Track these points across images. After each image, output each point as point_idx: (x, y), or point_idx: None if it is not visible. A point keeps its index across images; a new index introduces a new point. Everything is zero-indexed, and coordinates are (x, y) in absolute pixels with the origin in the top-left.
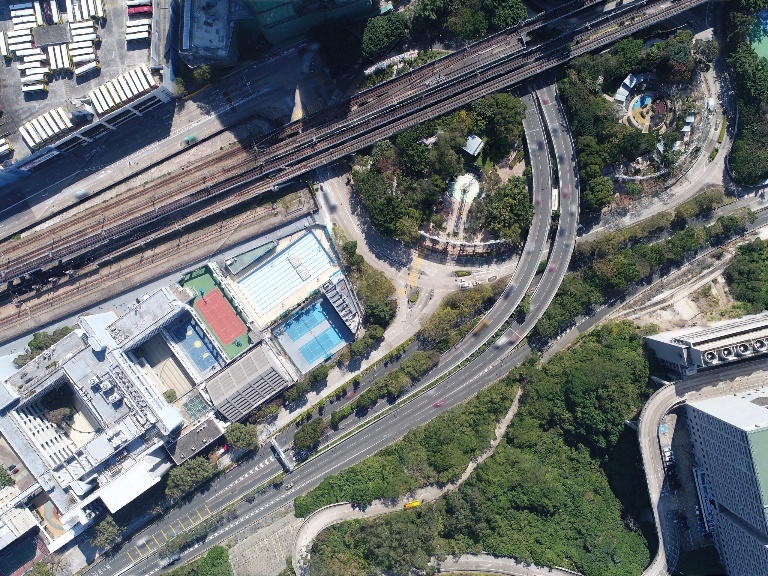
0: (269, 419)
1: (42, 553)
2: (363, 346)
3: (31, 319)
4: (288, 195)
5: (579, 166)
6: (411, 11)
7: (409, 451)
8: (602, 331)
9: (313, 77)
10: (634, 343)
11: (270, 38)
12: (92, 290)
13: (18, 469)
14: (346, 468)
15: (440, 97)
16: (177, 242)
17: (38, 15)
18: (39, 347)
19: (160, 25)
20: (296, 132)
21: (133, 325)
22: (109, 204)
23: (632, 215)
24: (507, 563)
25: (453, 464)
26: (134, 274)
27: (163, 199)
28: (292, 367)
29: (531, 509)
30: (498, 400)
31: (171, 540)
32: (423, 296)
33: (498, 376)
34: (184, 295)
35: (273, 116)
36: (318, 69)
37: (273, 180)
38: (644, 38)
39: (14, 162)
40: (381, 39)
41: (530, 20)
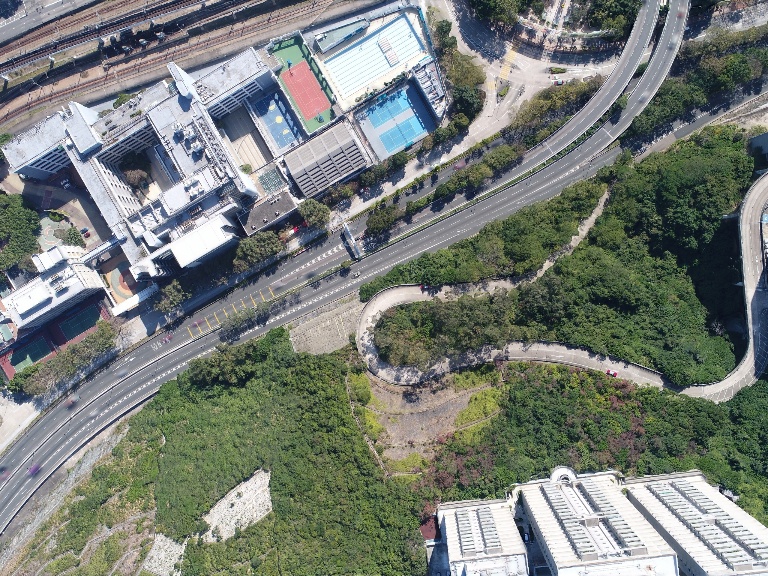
0: (342, 206)
1: None
2: (447, 132)
3: (117, 84)
4: None
5: None
6: None
7: (485, 241)
8: (703, 133)
9: None
10: (738, 143)
11: None
12: (179, 59)
13: (90, 233)
14: None
15: None
16: (268, 16)
17: None
18: None
19: None
20: None
21: (219, 83)
22: None
23: (745, 22)
24: (580, 355)
25: (531, 254)
26: (222, 46)
27: None
28: (371, 154)
29: (610, 305)
30: (584, 196)
31: None
32: (513, 91)
33: (585, 178)
34: (272, 62)
35: None
36: None
37: None
38: None
39: None
40: None
41: None
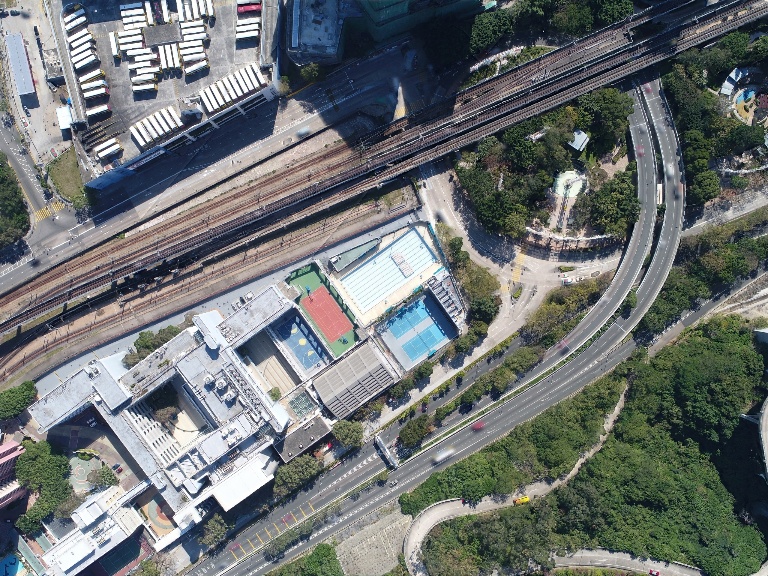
0: (372, 416)
1: (146, 552)
2: (469, 342)
3: (135, 318)
4: (391, 192)
5: (685, 160)
6: (519, 7)
7: (517, 447)
8: (710, 325)
9: (416, 74)
10: (745, 337)
11: (377, 35)
12: (195, 289)
13: (122, 468)
14: (451, 465)
15: (546, 93)
16: (280, 240)
17: (149, 15)
18: (146, 346)
19: (267, 24)
20: (400, 129)
21: (243, 323)
22: (214, 203)
23: (735, 209)
24: (623, 558)
25: (564, 459)
26: (237, 272)
27: (268, 197)
28: (395, 364)
29: (644, 504)
30: (606, 395)
31: (275, 538)
32: (526, 292)
33: (603, 371)
34: (292, 293)
35: (376, 113)
36: (421, 66)
37: (378, 177)
38: (748, 32)
39: (123, 162)
40: (489, 35)
41: (638, 15)
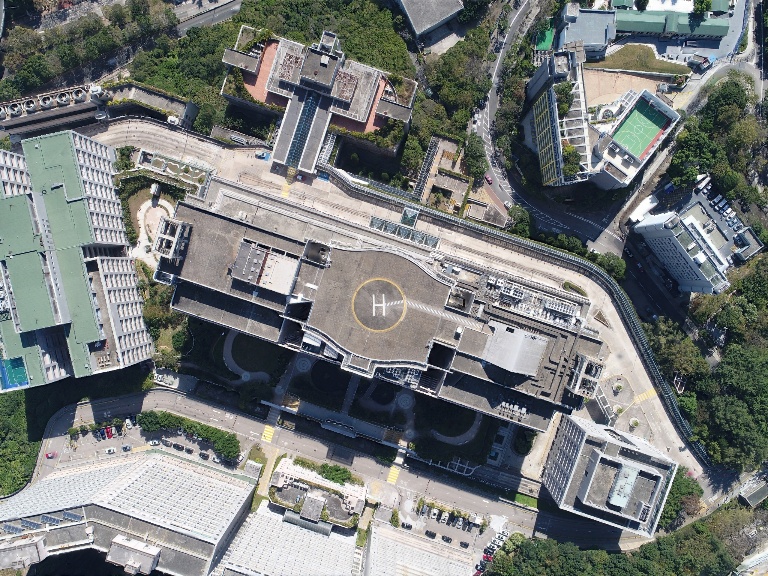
0: None
1: None
2: None
3: None
4: None
5: None
6: None
7: None
8: None
9: None
10: None
11: None
12: None
13: None
14: None
15: None
16: None
17: None
18: None
19: None
20: None
21: None
22: None
23: (72, 19)
24: None
25: None
26: None
27: None
28: None
29: None
30: None
31: None
32: None
33: None
34: None
35: None
36: None
37: None
38: None
39: None
40: None
41: None
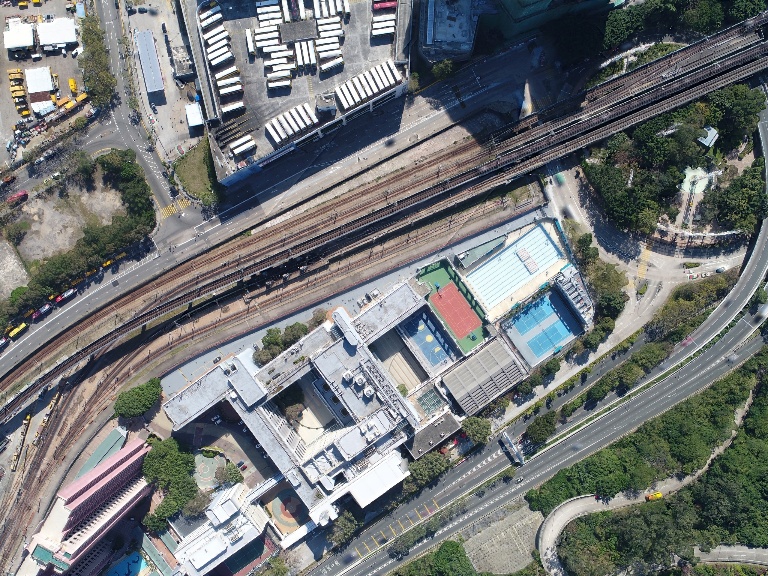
0: None
1: (270, 550)
2: None
3: (260, 315)
4: (517, 189)
5: None
6: (653, 4)
7: (648, 443)
8: None
9: (543, 71)
10: None
11: (509, 32)
12: (321, 286)
13: (246, 466)
14: (577, 461)
15: (676, 89)
16: (406, 237)
17: (285, 11)
18: (276, 343)
19: (400, 20)
20: None
21: (377, 319)
22: (341, 199)
23: None
24: (761, 553)
25: (698, 455)
26: (363, 269)
27: (396, 194)
28: (521, 360)
29: None
30: (738, 391)
31: (400, 535)
32: (651, 288)
33: (730, 367)
34: (423, 289)
35: (503, 110)
36: (548, 63)
37: (507, 174)
38: None
39: (256, 158)
40: (622, 32)
41: None
